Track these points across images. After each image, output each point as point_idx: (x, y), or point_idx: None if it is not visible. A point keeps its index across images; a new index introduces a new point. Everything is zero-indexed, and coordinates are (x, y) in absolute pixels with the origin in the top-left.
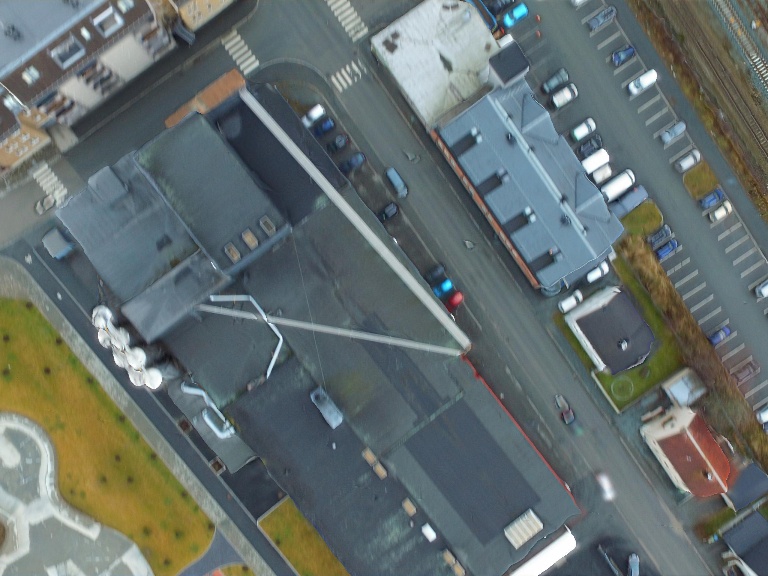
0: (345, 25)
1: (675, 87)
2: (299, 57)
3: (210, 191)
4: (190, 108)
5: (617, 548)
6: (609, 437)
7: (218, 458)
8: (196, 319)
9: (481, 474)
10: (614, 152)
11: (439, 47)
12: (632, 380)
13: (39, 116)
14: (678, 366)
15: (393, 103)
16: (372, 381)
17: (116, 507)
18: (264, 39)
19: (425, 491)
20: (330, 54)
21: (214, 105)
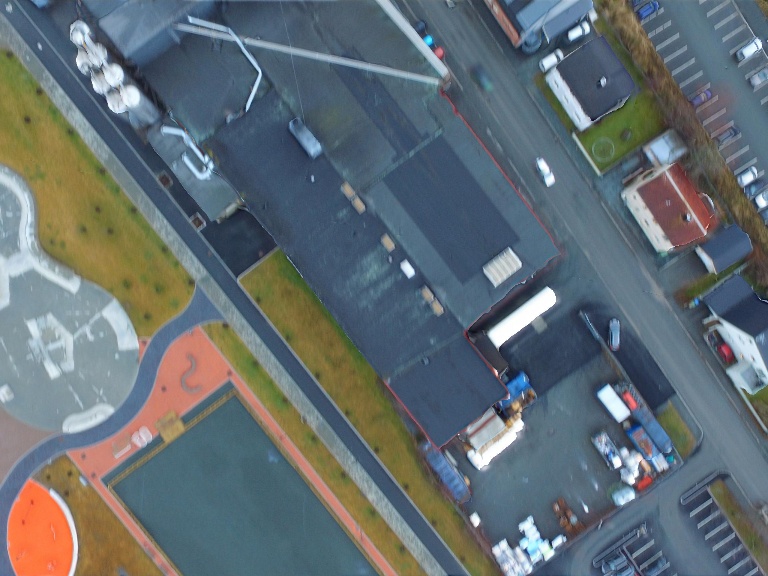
0: None
1: None
2: None
3: None
4: None
5: (598, 314)
6: (590, 201)
7: (198, 214)
8: (174, 40)
9: (460, 212)
10: None
11: None
12: (613, 142)
13: None
14: (659, 128)
15: None
16: (351, 116)
17: (96, 258)
18: None
19: (404, 227)
20: None
21: None
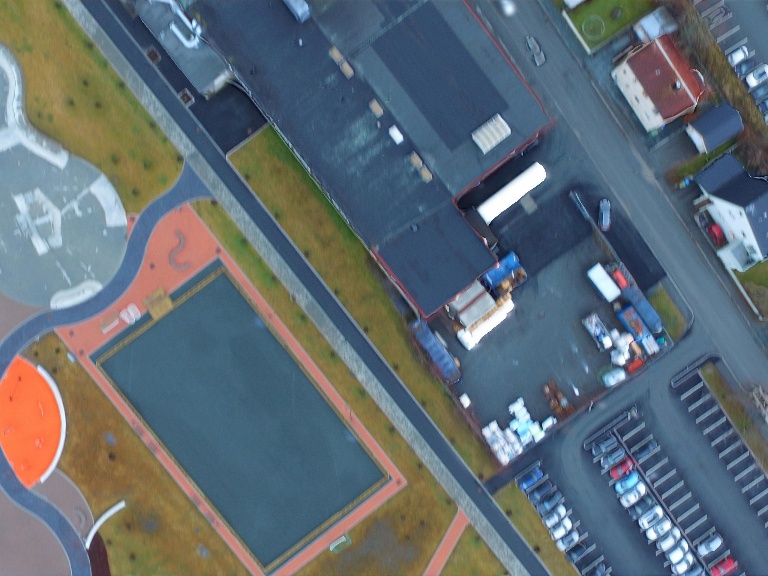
0: None
1: None
2: None
3: None
4: None
5: (588, 194)
6: (580, 80)
7: (187, 90)
8: None
9: (449, 78)
10: None
11: None
12: (603, 20)
13: None
14: (649, 7)
15: None
16: None
17: (84, 132)
18: None
19: (392, 93)
20: None
21: None
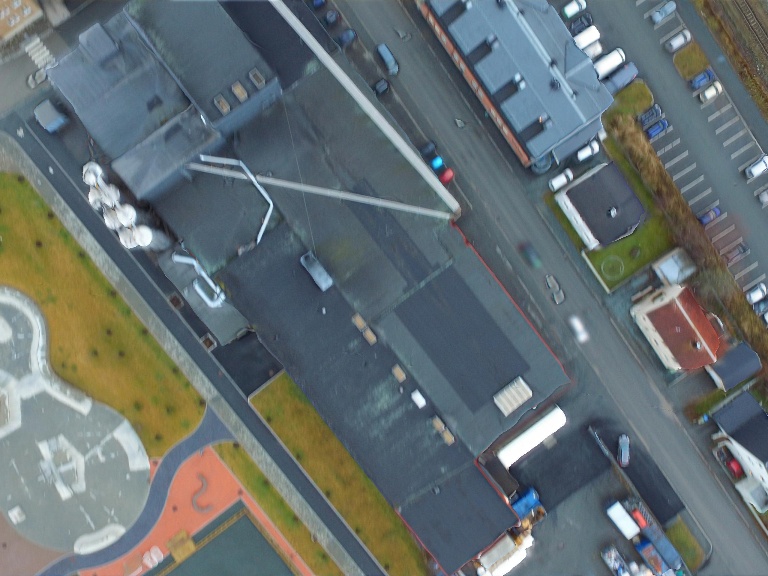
0: None
1: None
2: None
3: (200, 44)
4: None
5: (607, 429)
6: (599, 318)
7: (209, 335)
8: (186, 178)
9: (471, 341)
10: (605, 32)
11: None
12: (622, 260)
13: None
14: (668, 246)
15: None
16: (362, 247)
17: (107, 381)
18: None
19: (415, 357)
20: None
21: None
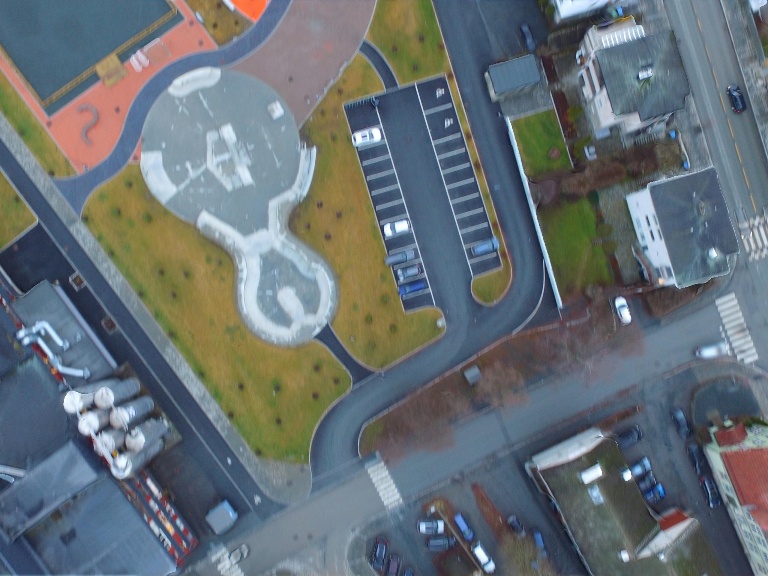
0: None
1: None
2: None
3: None
4: None
5: None
6: None
7: (77, 290)
8: None
9: None
10: None
11: None
12: None
13: None
14: None
15: None
16: None
17: (177, 245)
18: None
19: None
20: None
21: None
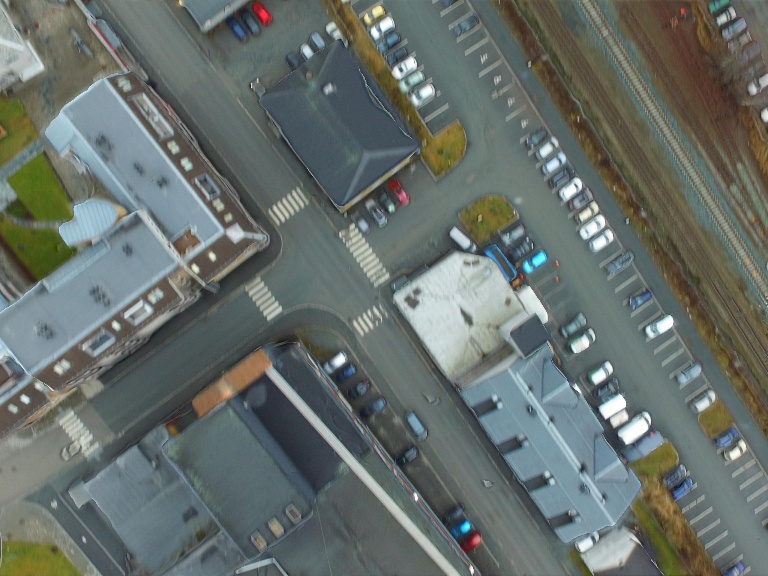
0: (367, 271)
1: (691, 329)
2: (321, 303)
3: (237, 480)
4: (217, 389)
5: None
6: None
7: None
8: None
9: None
10: (631, 393)
11: (460, 302)
12: None
13: (68, 385)
14: None
15: (414, 347)
16: None
17: None
18: (287, 286)
19: None
20: (352, 299)
21: (241, 388)
